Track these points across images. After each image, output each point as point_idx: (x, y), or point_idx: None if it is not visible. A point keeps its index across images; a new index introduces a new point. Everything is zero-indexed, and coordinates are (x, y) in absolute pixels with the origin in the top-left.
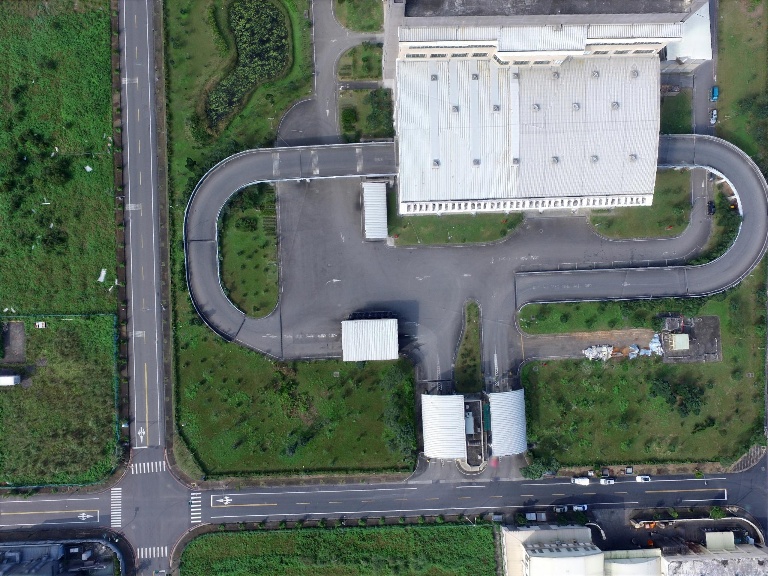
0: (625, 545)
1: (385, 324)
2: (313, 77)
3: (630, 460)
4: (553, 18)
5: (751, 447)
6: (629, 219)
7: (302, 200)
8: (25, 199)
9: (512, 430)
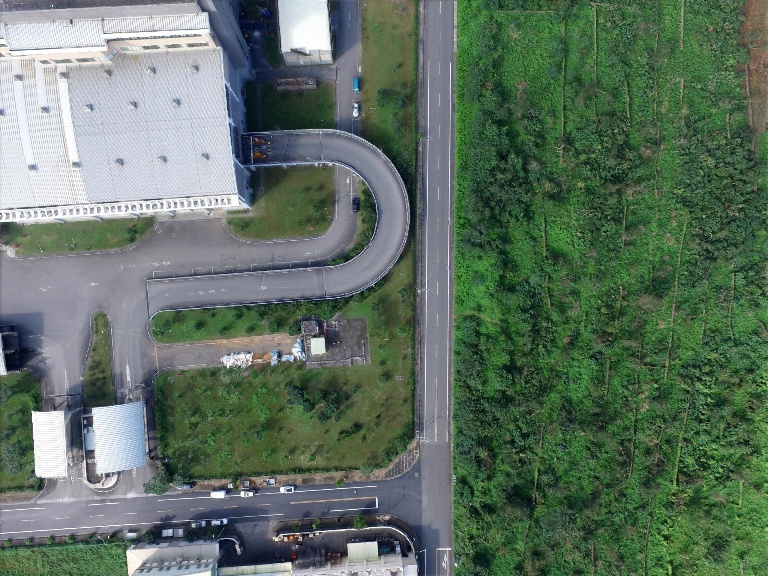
0: (268, 559)
1: None
2: None
3: (272, 471)
4: (51, 13)
5: (403, 453)
6: (268, 220)
7: None
8: None
9: (120, 445)
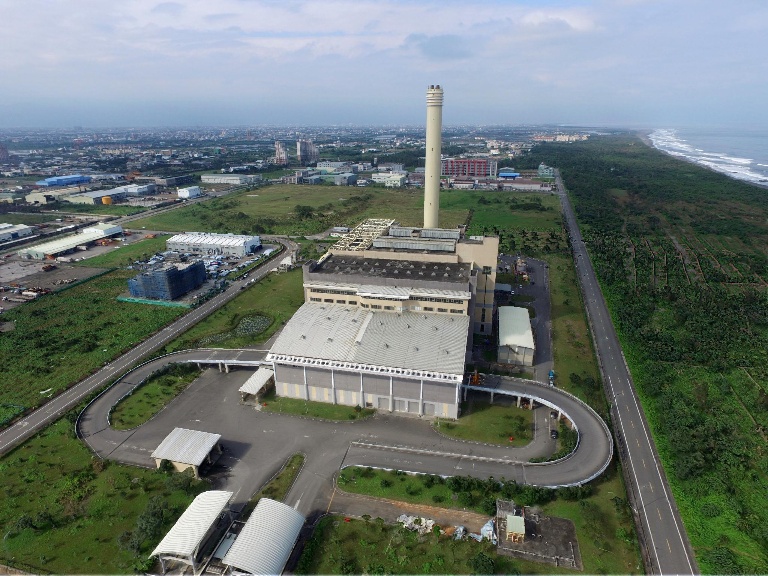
0: None
1: (208, 436)
2: (269, 338)
3: None
4: (389, 281)
5: None
6: (471, 428)
7: (215, 380)
8: (55, 355)
9: (264, 543)
